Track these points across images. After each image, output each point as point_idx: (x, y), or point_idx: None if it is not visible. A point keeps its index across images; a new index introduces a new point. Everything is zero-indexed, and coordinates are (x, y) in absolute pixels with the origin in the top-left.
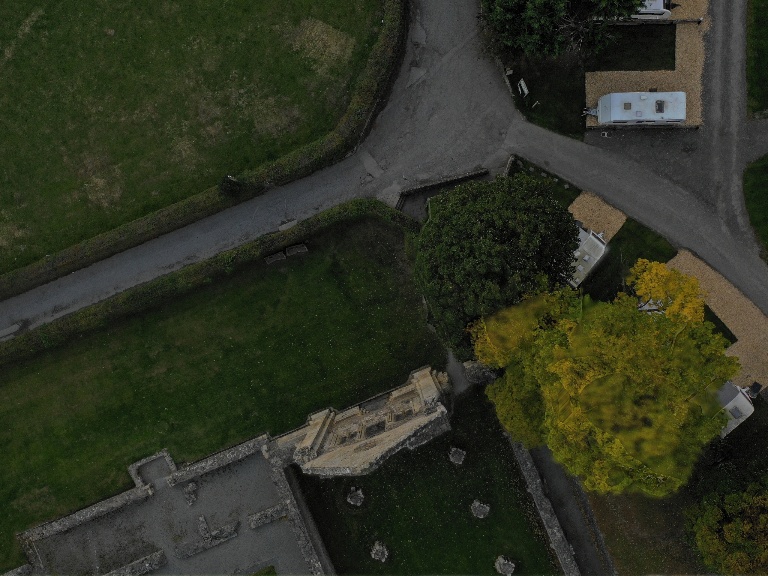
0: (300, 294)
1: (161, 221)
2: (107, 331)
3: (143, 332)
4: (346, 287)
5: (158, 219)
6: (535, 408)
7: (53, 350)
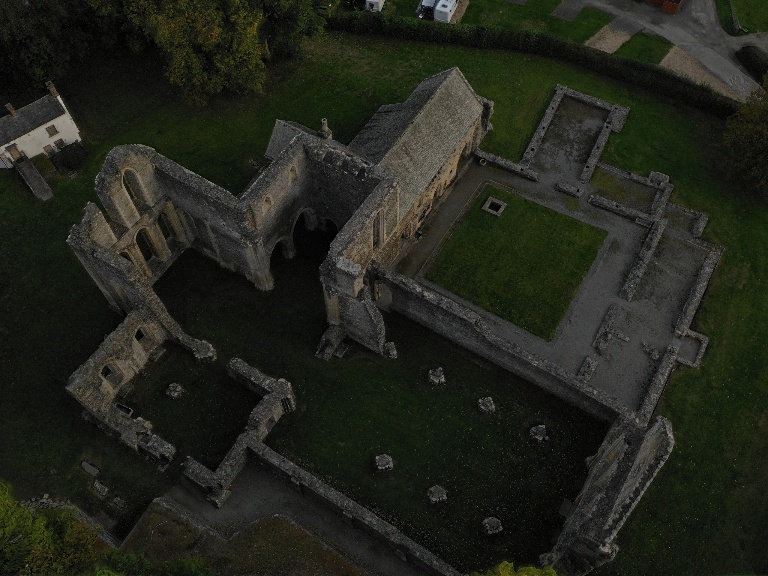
0: (734, 569)
1: None
2: None
3: None
4: None
5: None
6: None
7: None
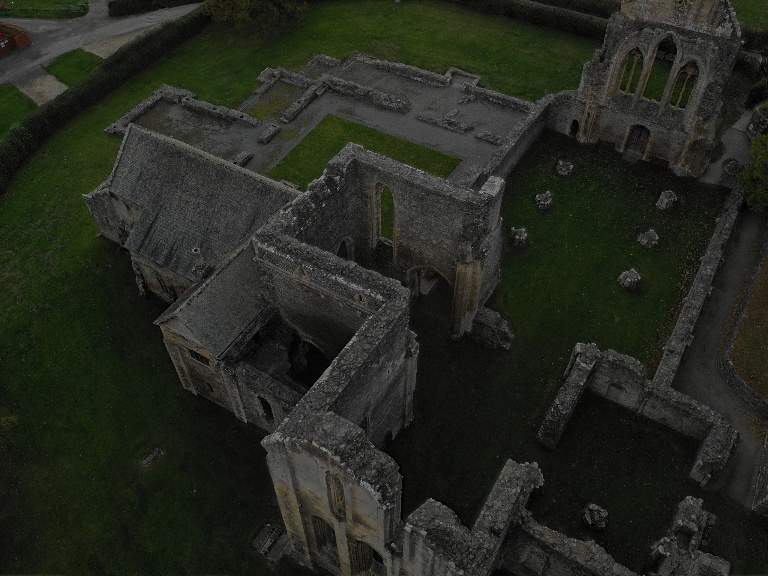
0: (651, 76)
1: (615, 2)
2: (521, 25)
3: (539, 36)
4: (685, 91)
5: (614, 0)
6: None
7: (484, 14)
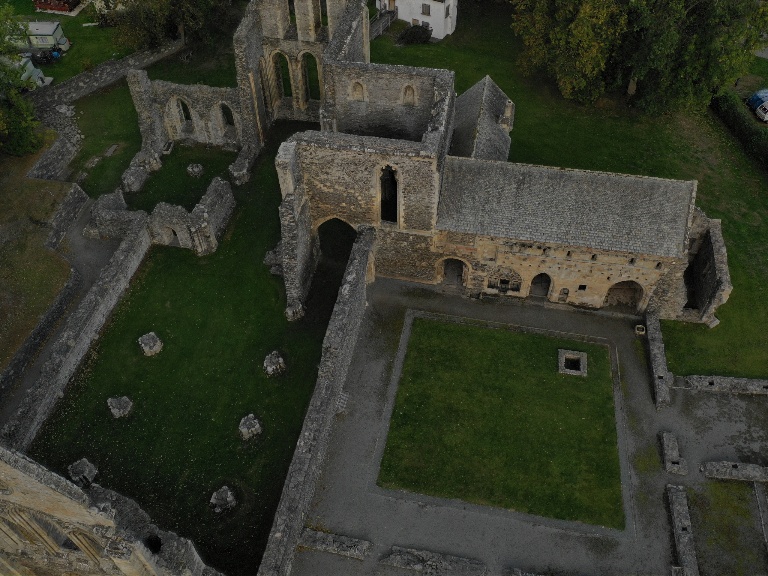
0: None
1: None
2: None
3: None
4: None
5: None
6: None
7: None
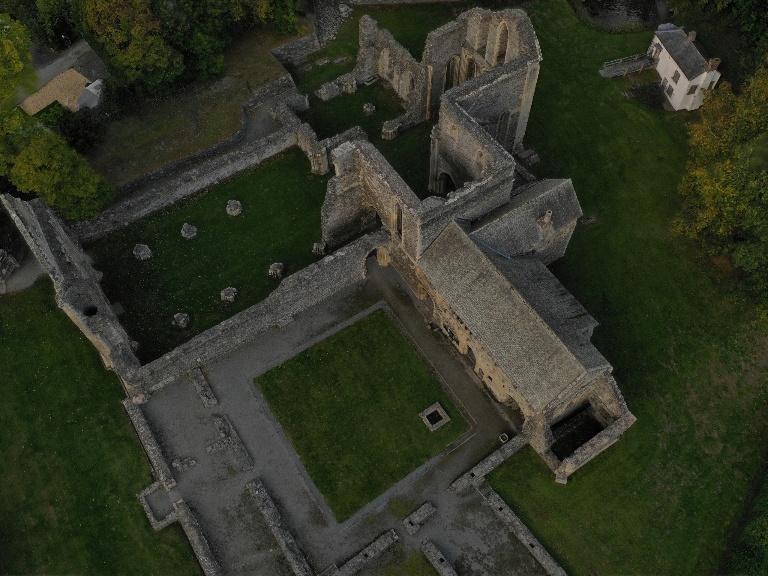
0: None
1: None
2: None
3: (8, 536)
4: None
5: None
6: (24, 148)
7: None
